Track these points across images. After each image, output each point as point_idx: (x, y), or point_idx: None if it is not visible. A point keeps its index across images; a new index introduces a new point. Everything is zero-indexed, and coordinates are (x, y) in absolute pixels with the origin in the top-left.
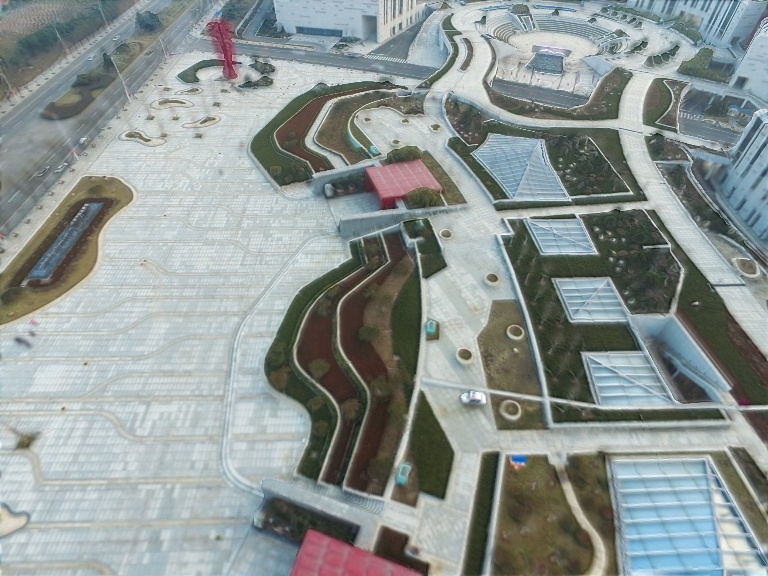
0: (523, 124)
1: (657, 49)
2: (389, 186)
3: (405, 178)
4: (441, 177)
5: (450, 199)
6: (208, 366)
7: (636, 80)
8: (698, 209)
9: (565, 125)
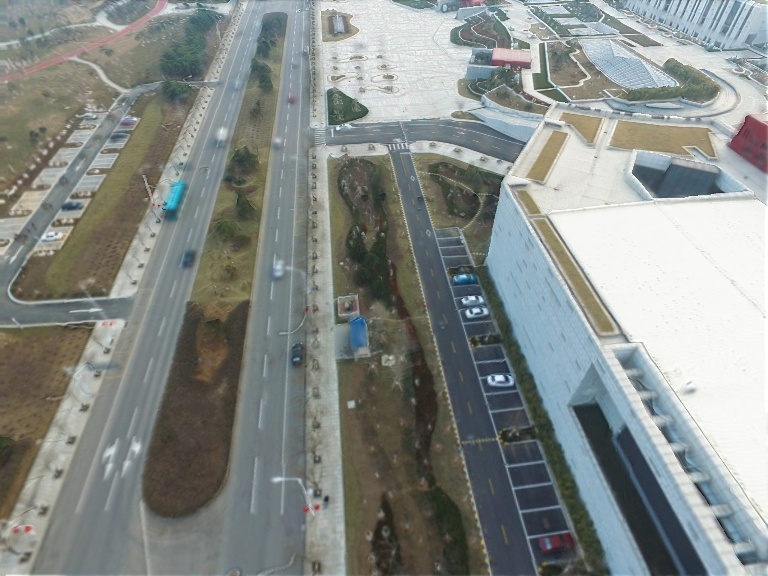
0: None
1: None
2: None
3: None
4: None
5: (504, 3)
6: None
7: None
8: (611, 1)
9: None
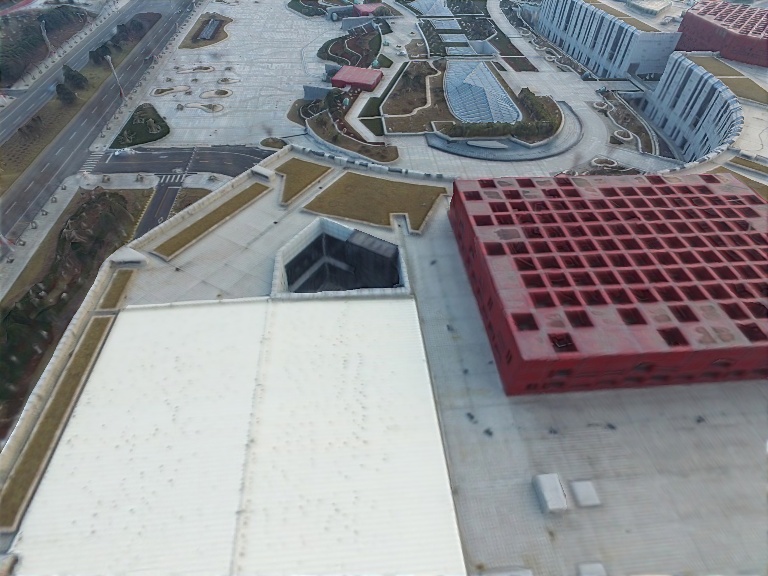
0: None
1: None
2: (365, 9)
3: (373, 7)
4: None
5: (395, 14)
6: (293, 57)
7: None
8: (512, 17)
9: None
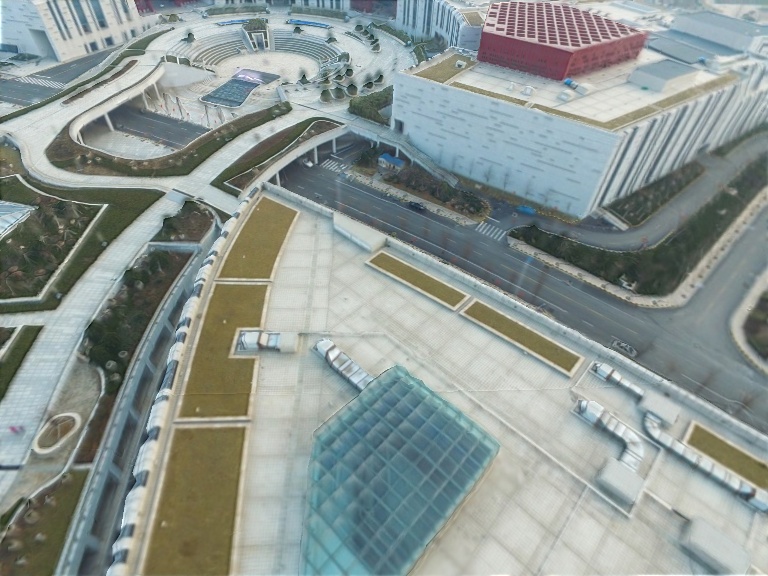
0: (49, 182)
1: (367, 78)
2: None
3: None
4: None
5: None
6: None
7: (282, 120)
8: (88, 328)
9: (106, 184)
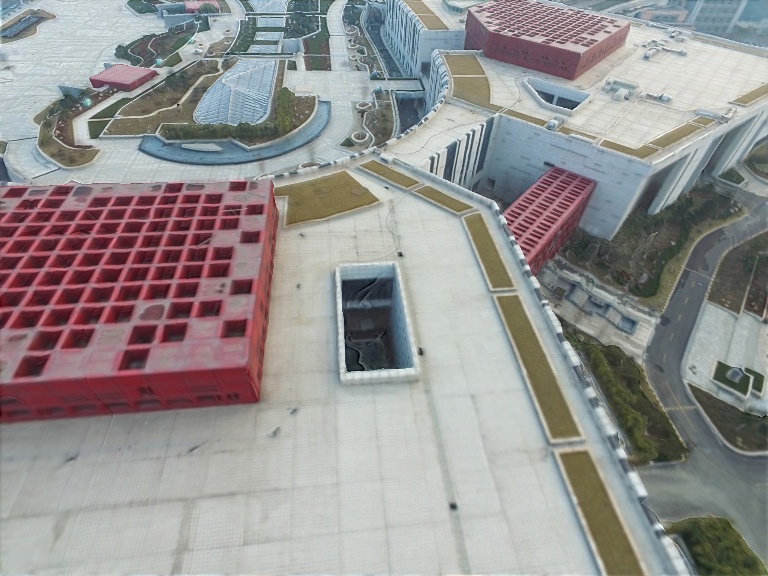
0: None
1: None
2: (192, 6)
3: None
4: (224, 6)
5: None
6: (90, 56)
7: None
8: (345, 15)
9: None
